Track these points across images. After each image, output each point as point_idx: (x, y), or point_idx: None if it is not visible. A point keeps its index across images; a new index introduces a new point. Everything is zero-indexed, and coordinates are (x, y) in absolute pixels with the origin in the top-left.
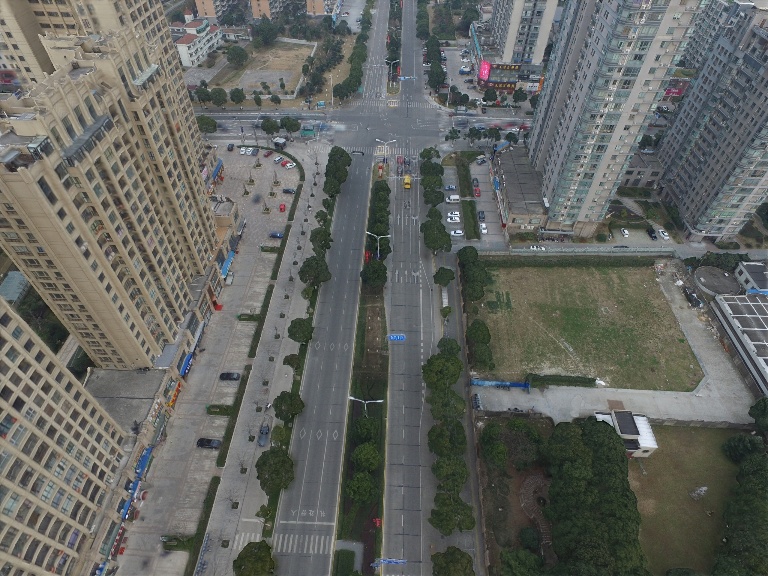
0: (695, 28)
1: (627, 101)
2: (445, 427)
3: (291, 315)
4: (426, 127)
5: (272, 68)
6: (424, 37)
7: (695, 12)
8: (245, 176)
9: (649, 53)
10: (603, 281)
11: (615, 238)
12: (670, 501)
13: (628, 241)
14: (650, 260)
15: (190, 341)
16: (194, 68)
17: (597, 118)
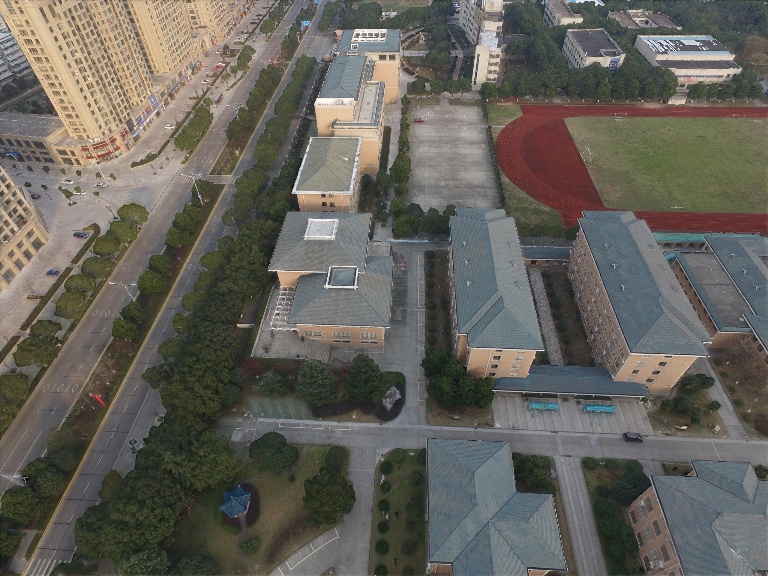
0: None
1: None
2: None
3: None
4: None
5: None
6: None
7: None
8: None
9: None
10: None
11: None
12: None
13: None
14: None
15: (246, 4)
16: None
17: None
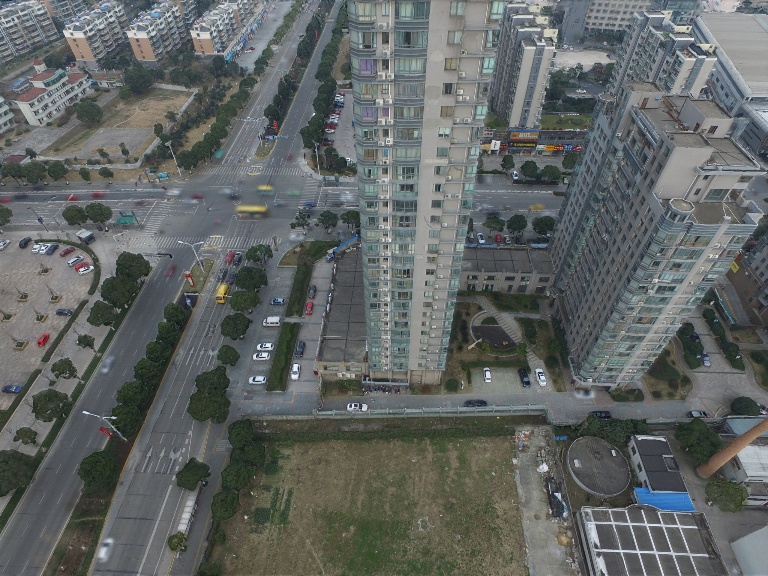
0: (632, 65)
1: (415, 241)
2: None
3: None
4: (283, 204)
5: (131, 125)
6: (323, 78)
7: (471, 126)
8: (21, 288)
9: (421, 182)
10: (435, 465)
11: (472, 384)
12: None
13: (489, 389)
14: (507, 429)
15: None
16: (41, 127)
17: (380, 261)
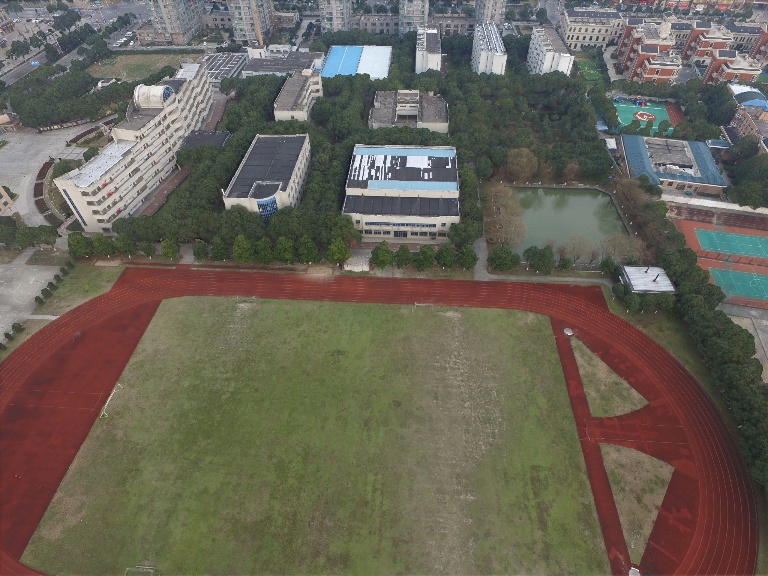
0: None
1: None
2: (26, 79)
3: (6, 68)
4: None
5: None
6: None
7: None
8: None
9: None
10: None
11: None
12: (112, 104)
13: None
14: (200, 49)
15: None
16: None
17: None
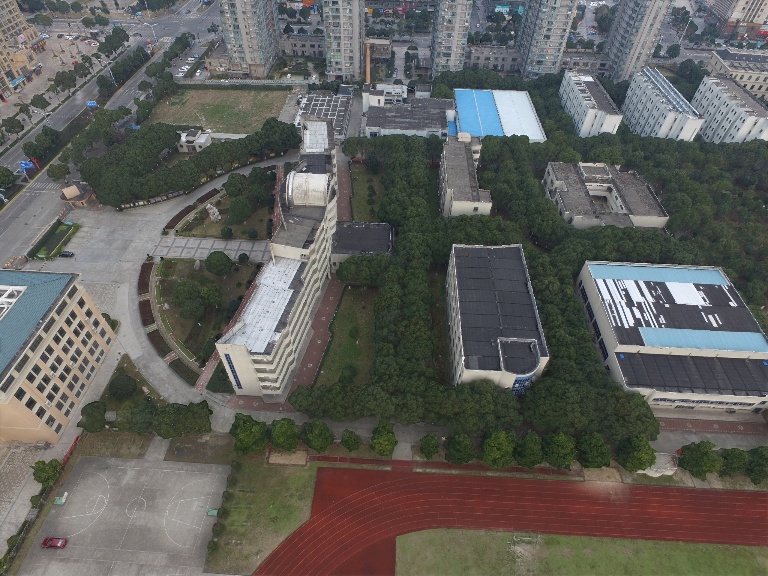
0: None
1: None
2: None
3: None
4: None
5: None
6: None
7: None
8: None
9: None
10: (253, 96)
11: (281, 79)
12: None
13: None
14: (288, 85)
15: None
16: None
17: None
